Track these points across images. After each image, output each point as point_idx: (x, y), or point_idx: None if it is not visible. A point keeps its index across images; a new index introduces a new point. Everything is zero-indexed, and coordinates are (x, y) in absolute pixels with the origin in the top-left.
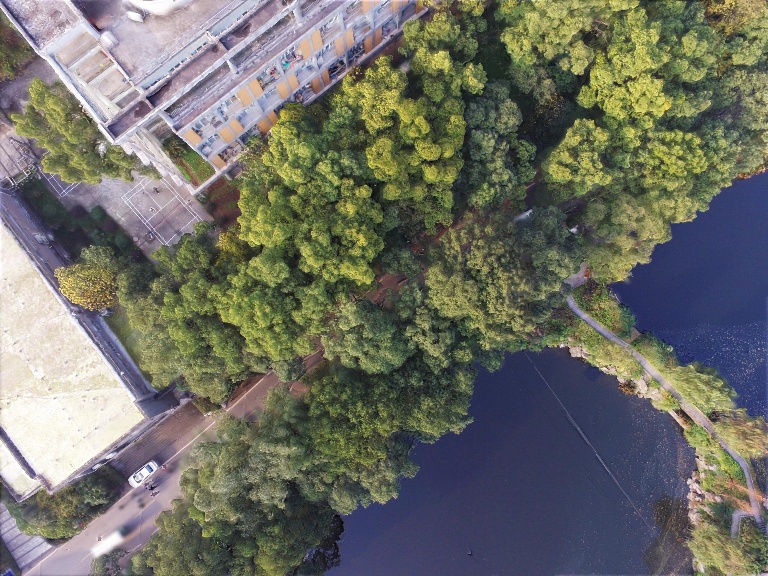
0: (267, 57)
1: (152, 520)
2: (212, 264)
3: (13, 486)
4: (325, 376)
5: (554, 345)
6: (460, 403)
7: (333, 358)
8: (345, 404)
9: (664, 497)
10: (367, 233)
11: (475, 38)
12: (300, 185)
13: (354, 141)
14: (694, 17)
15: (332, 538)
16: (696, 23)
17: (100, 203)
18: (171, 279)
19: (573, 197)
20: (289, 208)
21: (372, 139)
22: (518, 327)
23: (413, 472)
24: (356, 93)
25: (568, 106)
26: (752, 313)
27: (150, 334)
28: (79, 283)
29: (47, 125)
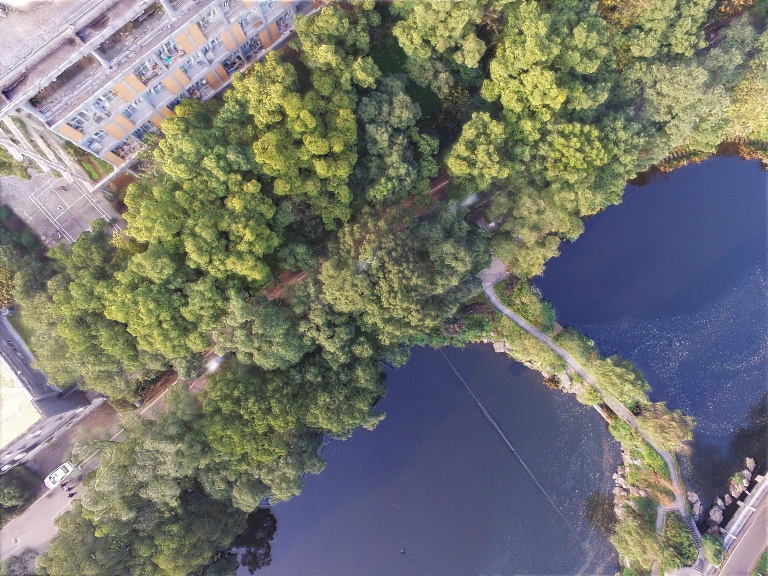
0: (142, 52)
1: None
2: (107, 261)
3: None
4: None
5: (476, 340)
6: (363, 399)
7: (234, 355)
8: (238, 401)
9: (590, 492)
10: (256, 228)
11: (366, 32)
12: (186, 180)
13: (243, 136)
14: (589, 9)
15: (265, 538)
16: (589, 15)
17: (7, 202)
18: (67, 277)
19: (480, 191)
20: (176, 204)
21: (263, 134)
22: (416, 321)
23: (320, 469)
24: (244, 88)
25: (476, 100)
26: (675, 306)
27: (45, 333)
28: None
29: None
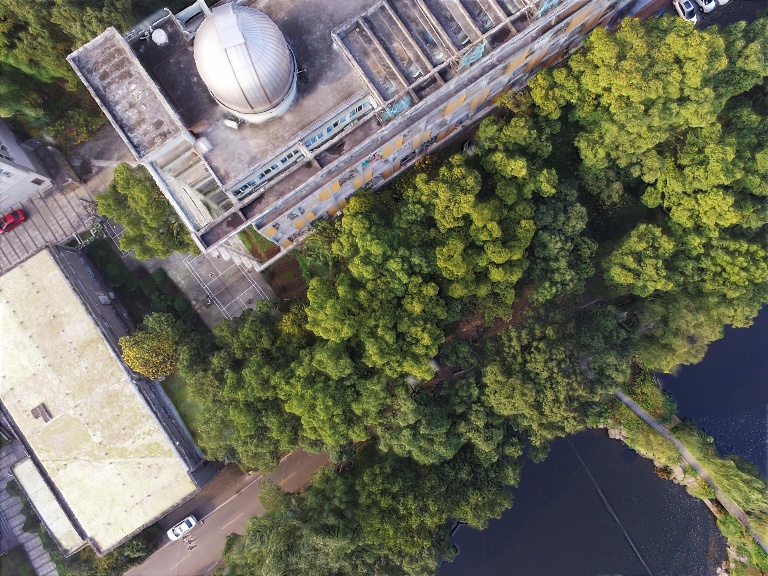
0: (351, 161)
1: (188, 573)
2: (273, 344)
3: (61, 541)
4: (374, 457)
5: (594, 426)
6: (506, 494)
7: None
8: (397, 495)
9: None
10: (431, 330)
11: (549, 141)
12: (370, 281)
13: (424, 238)
14: (767, 132)
15: None
16: None
17: (161, 265)
18: (232, 355)
19: (629, 293)
20: (357, 301)
21: (441, 235)
22: (571, 427)
23: (453, 556)
24: (430, 191)
25: (629, 200)
26: None
27: (209, 409)
28: (143, 354)
29: (127, 204)
